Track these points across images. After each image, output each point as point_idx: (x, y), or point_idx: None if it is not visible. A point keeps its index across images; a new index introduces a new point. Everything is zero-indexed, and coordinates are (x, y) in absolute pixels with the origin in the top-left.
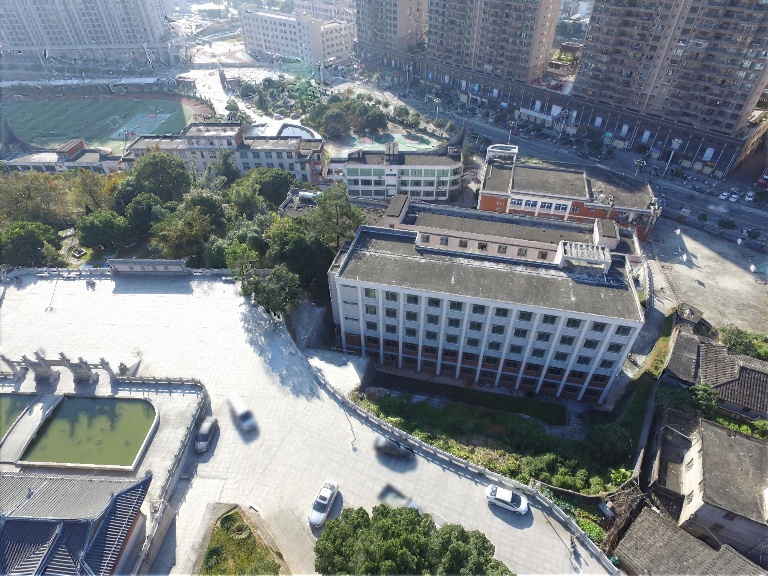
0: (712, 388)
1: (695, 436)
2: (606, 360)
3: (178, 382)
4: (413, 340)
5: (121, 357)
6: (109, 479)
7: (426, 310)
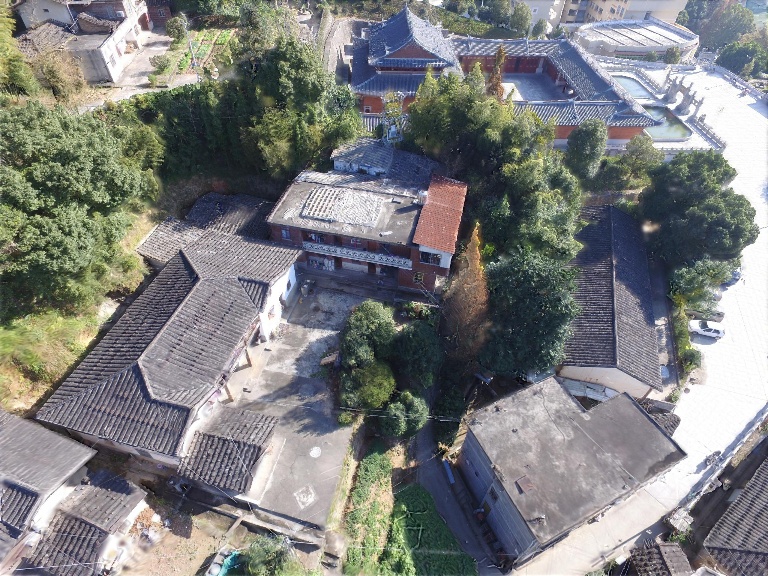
0: None
1: None
2: None
3: (716, 141)
4: None
5: (706, 122)
6: None
7: None
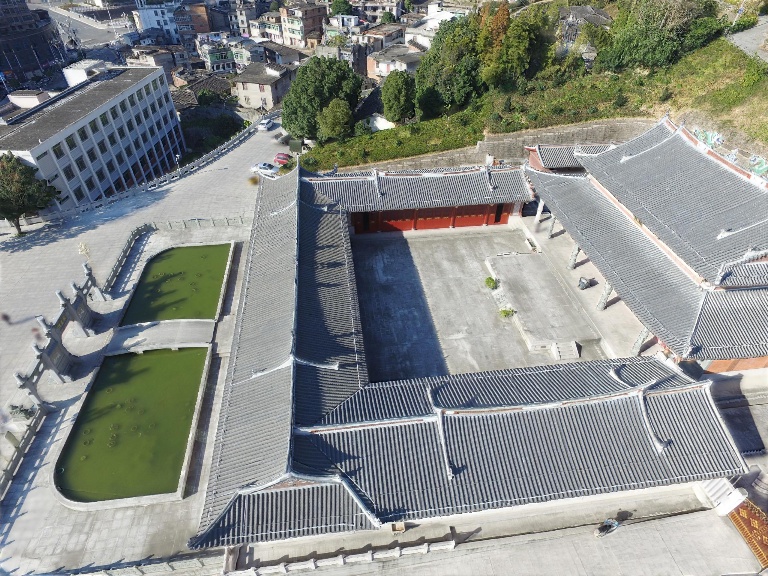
0: (197, 100)
1: (234, 91)
2: (170, 111)
3: (128, 250)
4: (106, 184)
5: None
6: (260, 191)
7: (95, 140)
